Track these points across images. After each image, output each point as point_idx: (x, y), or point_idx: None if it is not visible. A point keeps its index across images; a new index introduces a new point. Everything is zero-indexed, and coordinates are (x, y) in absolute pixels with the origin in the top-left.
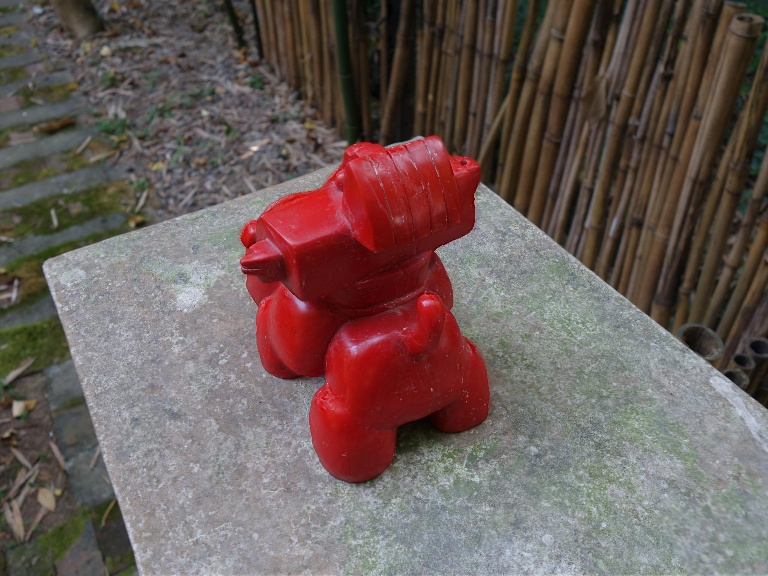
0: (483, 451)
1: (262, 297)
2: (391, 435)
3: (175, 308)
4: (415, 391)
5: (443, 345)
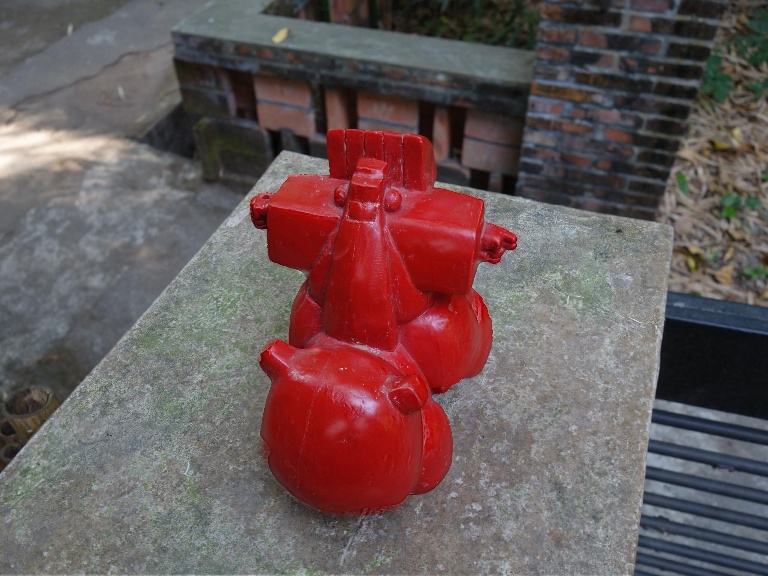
0: None
1: None
2: None
3: None
4: None
5: None
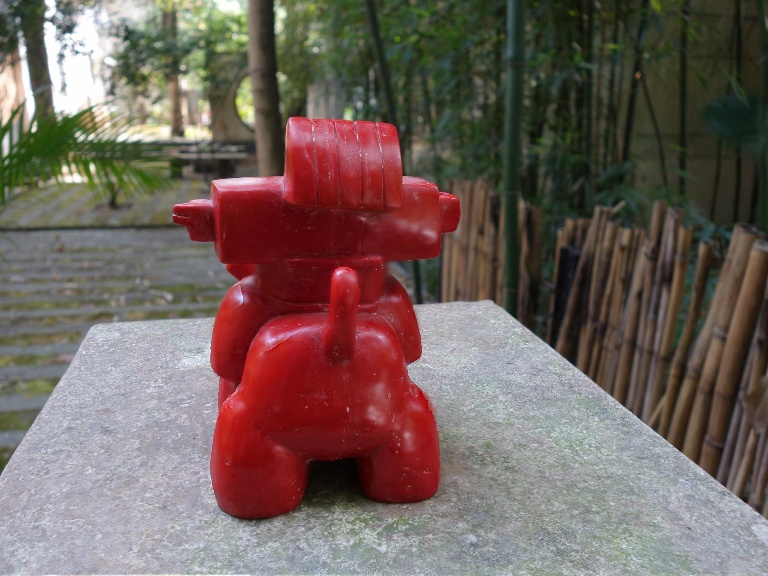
0: (407, 525)
1: None
2: (292, 460)
3: (174, 366)
4: (326, 403)
5: (372, 359)
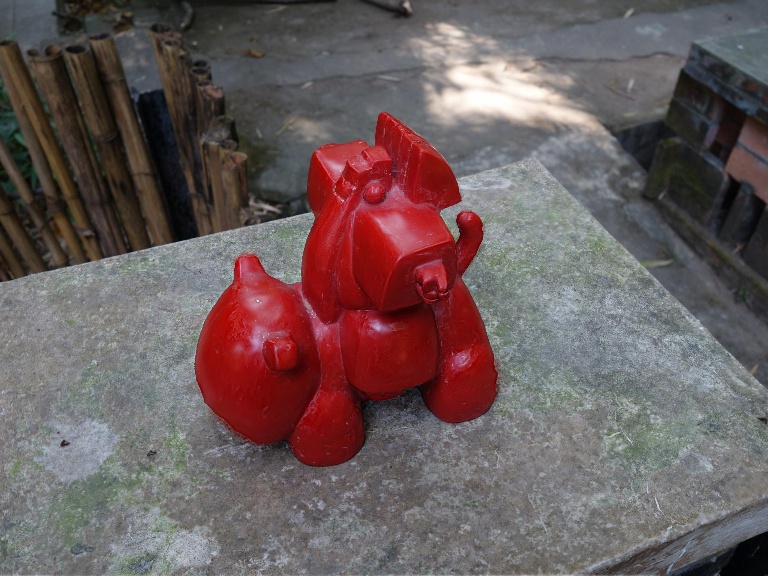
0: None
1: (304, 409)
2: None
3: (204, 567)
4: None
5: None
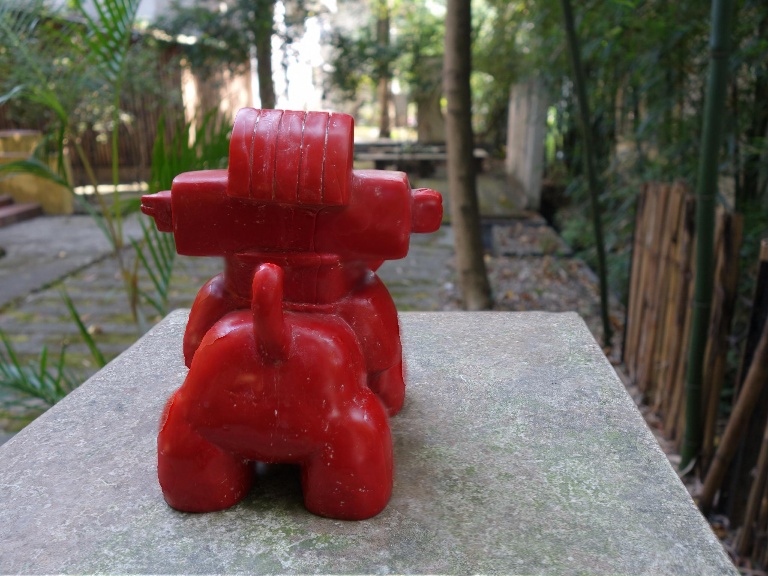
0: (326, 544)
1: None
2: (222, 458)
3: None
4: (254, 403)
5: (307, 363)
